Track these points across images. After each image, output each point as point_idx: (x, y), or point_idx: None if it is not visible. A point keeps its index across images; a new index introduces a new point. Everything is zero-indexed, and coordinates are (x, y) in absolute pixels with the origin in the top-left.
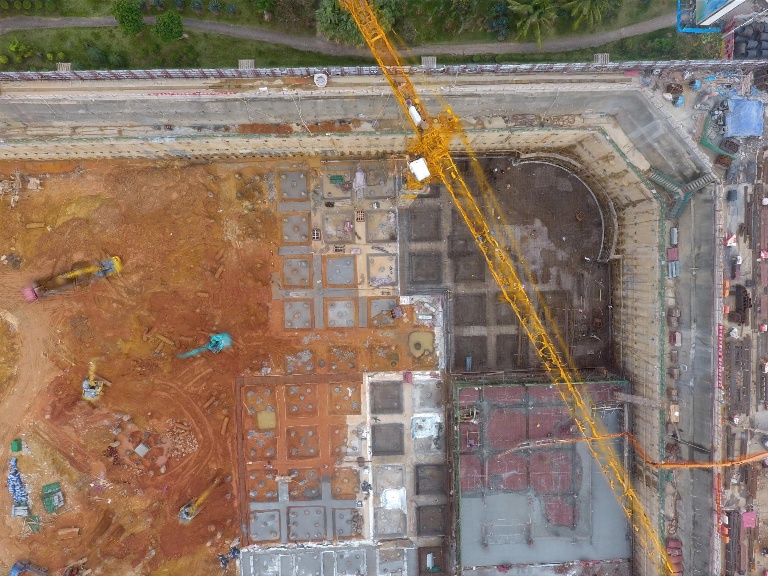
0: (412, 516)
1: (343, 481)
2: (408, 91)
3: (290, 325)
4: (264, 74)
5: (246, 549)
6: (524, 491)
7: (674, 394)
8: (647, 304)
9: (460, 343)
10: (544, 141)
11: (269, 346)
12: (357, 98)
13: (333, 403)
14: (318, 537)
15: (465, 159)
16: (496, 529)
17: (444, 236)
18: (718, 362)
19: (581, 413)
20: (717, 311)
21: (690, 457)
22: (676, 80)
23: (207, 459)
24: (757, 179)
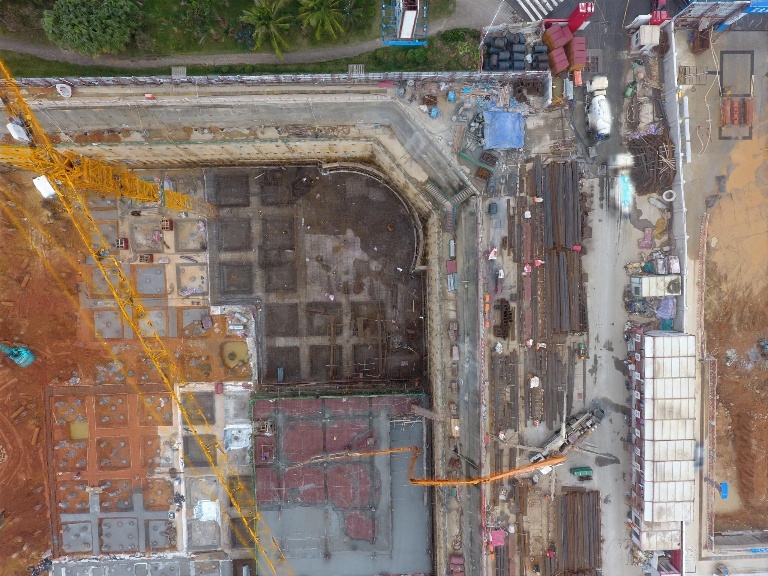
0: (225, 528)
1: (157, 492)
2: (19, 107)
3: (100, 335)
4: (5, 84)
5: (57, 560)
6: (322, 504)
7: (452, 408)
8: (435, 317)
9: (271, 354)
10: (335, 151)
11: (78, 356)
12: (106, 108)
13: (145, 414)
14: (132, 549)
15: (275, 168)
16: (293, 543)
17: (254, 246)
18: (481, 377)
19: (379, 426)
20: (480, 325)
21: (467, 472)
22: (433, 91)
23: (17, 469)
24: (519, 192)
